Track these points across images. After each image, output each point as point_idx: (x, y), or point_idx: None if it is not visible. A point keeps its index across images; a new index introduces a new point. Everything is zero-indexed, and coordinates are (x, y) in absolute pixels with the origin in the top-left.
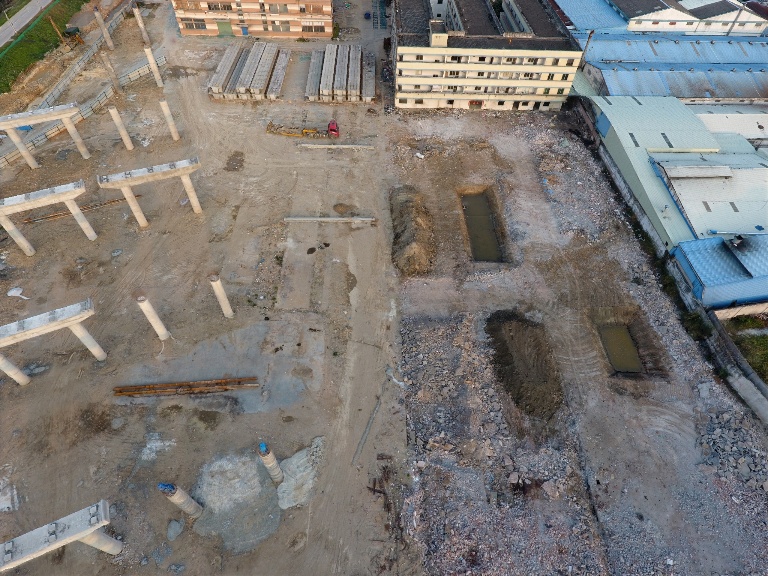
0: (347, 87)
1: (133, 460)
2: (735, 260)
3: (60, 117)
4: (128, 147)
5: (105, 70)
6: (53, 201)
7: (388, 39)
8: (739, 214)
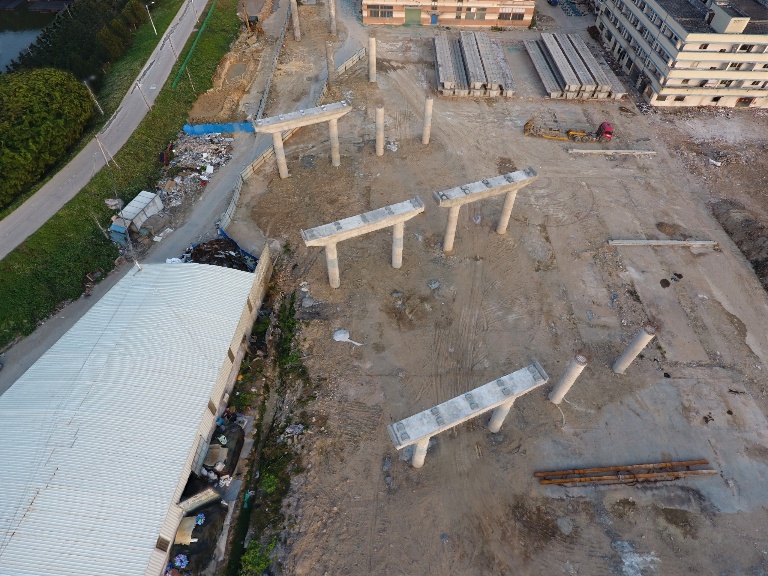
0: (597, 82)
1: None
2: None
3: (330, 118)
4: (379, 152)
5: (303, 63)
6: (389, 223)
7: (594, 27)
8: None
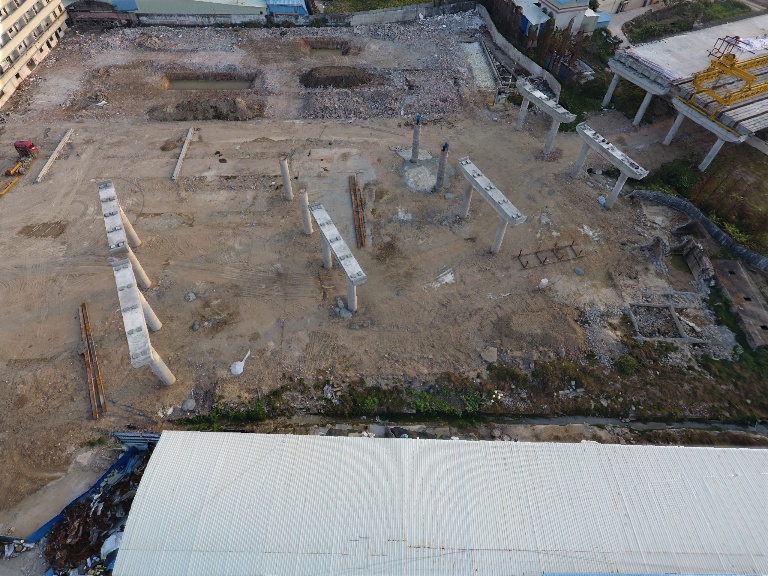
0: None
1: (412, 223)
2: None
3: None
4: None
5: None
6: None
7: None
8: None
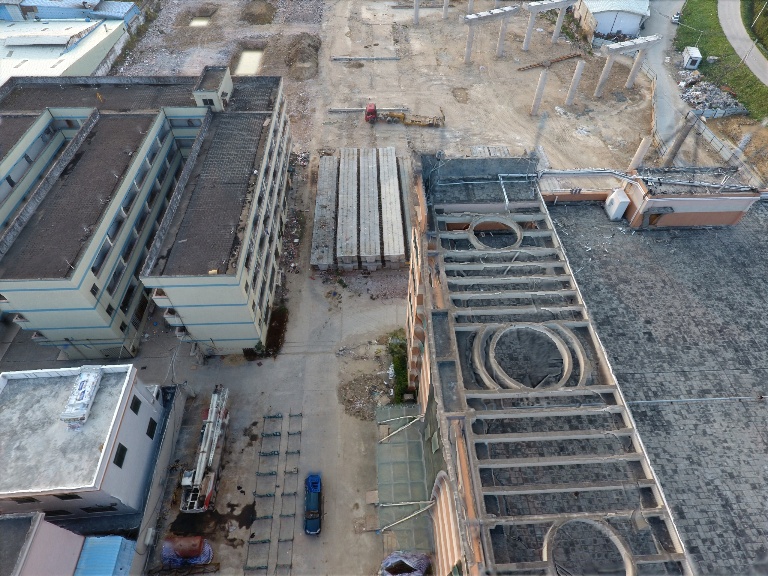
0: (358, 152)
1: None
2: (99, 5)
3: None
4: None
5: None
6: None
7: (273, 331)
8: (49, 27)
